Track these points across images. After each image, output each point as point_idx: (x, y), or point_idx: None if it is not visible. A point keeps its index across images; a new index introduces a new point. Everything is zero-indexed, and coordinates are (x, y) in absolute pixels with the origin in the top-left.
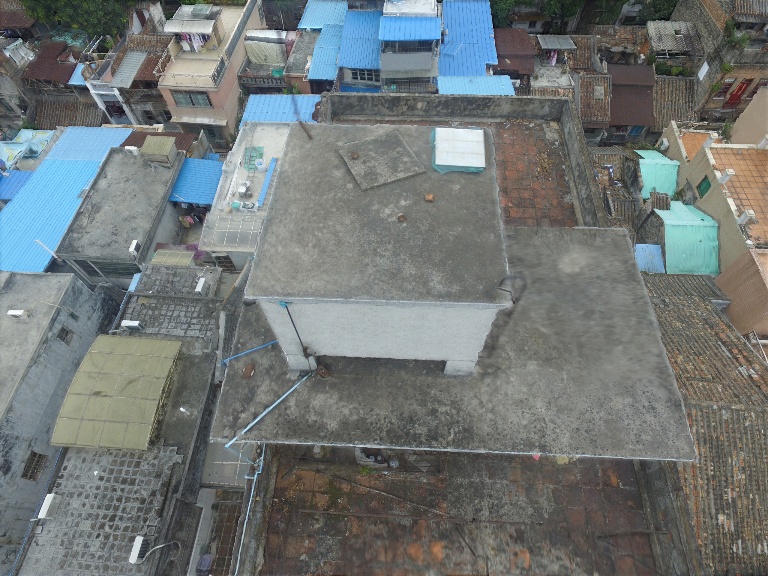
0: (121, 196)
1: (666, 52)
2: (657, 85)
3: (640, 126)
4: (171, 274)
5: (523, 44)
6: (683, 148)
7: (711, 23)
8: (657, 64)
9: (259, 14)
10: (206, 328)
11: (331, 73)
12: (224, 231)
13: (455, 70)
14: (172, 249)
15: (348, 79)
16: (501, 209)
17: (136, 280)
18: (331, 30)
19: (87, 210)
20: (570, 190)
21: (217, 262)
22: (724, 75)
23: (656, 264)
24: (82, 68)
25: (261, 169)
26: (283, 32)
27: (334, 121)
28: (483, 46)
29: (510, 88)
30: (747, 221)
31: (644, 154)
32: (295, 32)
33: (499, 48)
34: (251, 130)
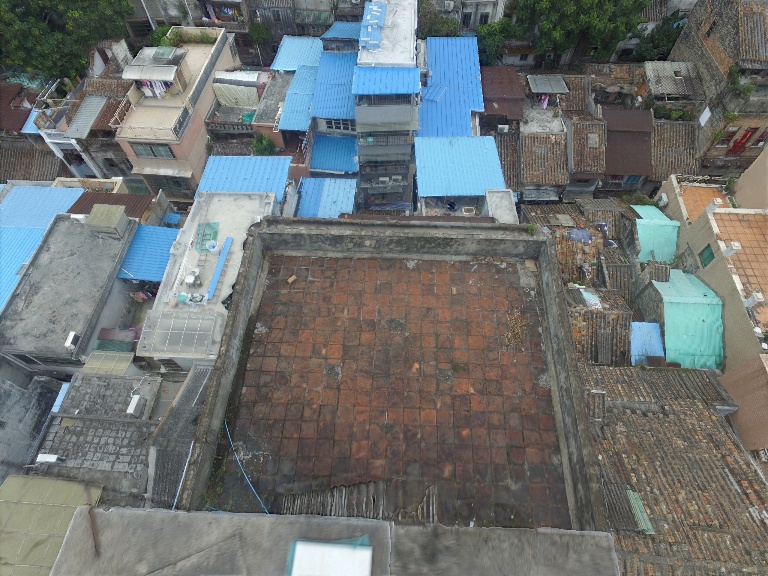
0: (63, 274)
1: (665, 96)
2: (655, 130)
3: (637, 175)
4: (103, 386)
5: (512, 86)
6: (684, 207)
7: (713, 66)
8: (655, 107)
9: (231, 52)
10: (137, 460)
11: (303, 123)
12: (166, 332)
13: (438, 118)
14: (118, 335)
15: (322, 128)
16: (460, 398)
17: (64, 392)
18: (305, 72)
19: (24, 291)
20: (547, 366)
21: (161, 362)
22: (728, 124)
23: (654, 346)
24: (35, 116)
25: (214, 252)
26: (254, 74)
27: (266, 258)
28: (469, 90)
29: (494, 152)
30: (755, 303)
31: (641, 211)
32: (267, 74)
33: (486, 90)
34: (206, 202)
